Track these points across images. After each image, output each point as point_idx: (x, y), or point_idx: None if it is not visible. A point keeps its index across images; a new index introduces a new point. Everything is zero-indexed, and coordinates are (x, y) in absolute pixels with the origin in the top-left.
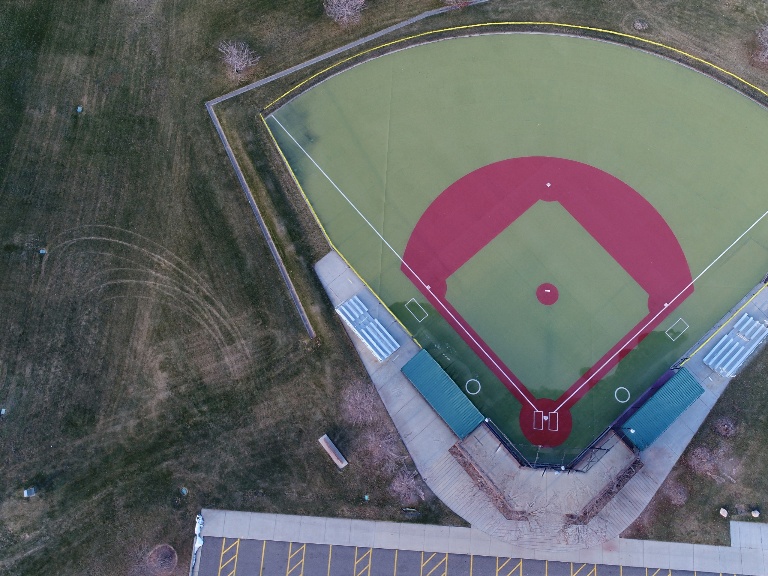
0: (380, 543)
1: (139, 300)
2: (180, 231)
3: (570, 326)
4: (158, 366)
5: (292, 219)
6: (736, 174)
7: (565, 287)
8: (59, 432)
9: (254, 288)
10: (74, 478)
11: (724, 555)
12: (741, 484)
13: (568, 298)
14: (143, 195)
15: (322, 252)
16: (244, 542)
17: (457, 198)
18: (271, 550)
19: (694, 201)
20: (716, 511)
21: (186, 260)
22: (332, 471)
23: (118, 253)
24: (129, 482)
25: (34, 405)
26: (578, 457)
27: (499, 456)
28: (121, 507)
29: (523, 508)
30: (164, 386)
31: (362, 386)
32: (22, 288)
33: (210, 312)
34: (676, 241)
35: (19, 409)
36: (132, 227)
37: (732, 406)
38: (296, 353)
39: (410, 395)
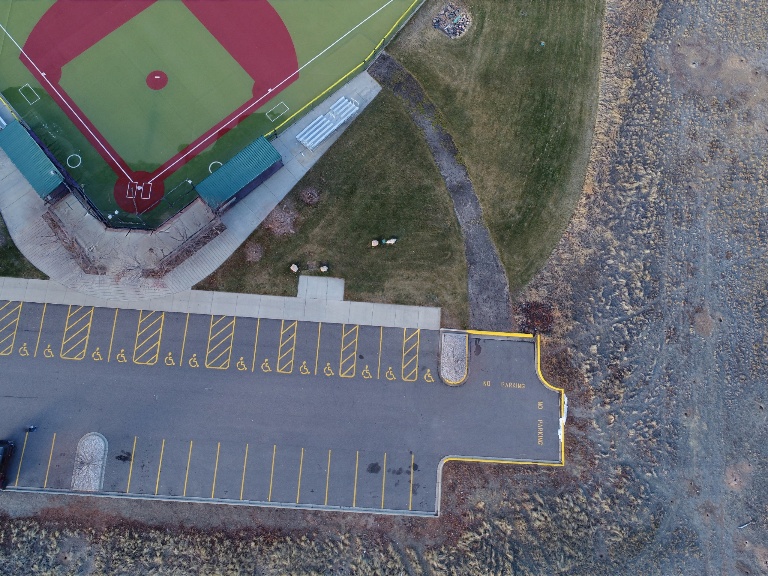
0: None
1: None
2: None
3: (175, 108)
4: None
5: None
6: None
7: (175, 74)
8: None
9: None
10: None
11: (289, 304)
12: (316, 244)
13: (176, 84)
14: None
15: None
16: None
17: None
18: None
19: None
20: (287, 267)
21: None
22: None
23: None
24: None
25: None
26: (166, 222)
27: (87, 219)
28: None
29: None
30: None
31: None
32: None
33: None
34: (288, 35)
35: None
36: None
37: (319, 178)
38: None
39: (12, 168)
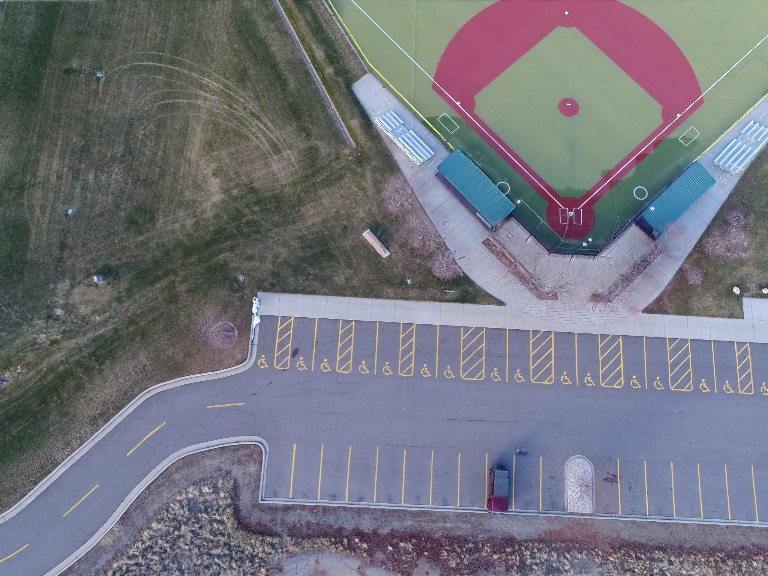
0: (423, 320)
1: (191, 117)
2: (226, 57)
3: (590, 134)
4: (211, 173)
5: (330, 46)
6: (740, 2)
7: (585, 101)
8: (122, 229)
9: (297, 106)
10: (138, 268)
11: (738, 326)
12: (752, 266)
13: (588, 110)
14: (190, 26)
15: (359, 74)
16: (298, 320)
17: (482, 26)
18: (323, 326)
19: (701, 25)
20: (729, 289)
21: (233, 82)
22: (376, 260)
23: (169, 76)
24: (189, 272)
25: (98, 206)
26: (602, 247)
27: (529, 245)
28: (183, 292)
29: (553, 289)
30: (217, 190)
31: (400, 189)
32: (82, 106)
33: (257, 126)
34: (686, 60)
35: (85, 209)
36: (181, 54)
37: (741, 201)
38: (338, 161)
39: (445, 196)
